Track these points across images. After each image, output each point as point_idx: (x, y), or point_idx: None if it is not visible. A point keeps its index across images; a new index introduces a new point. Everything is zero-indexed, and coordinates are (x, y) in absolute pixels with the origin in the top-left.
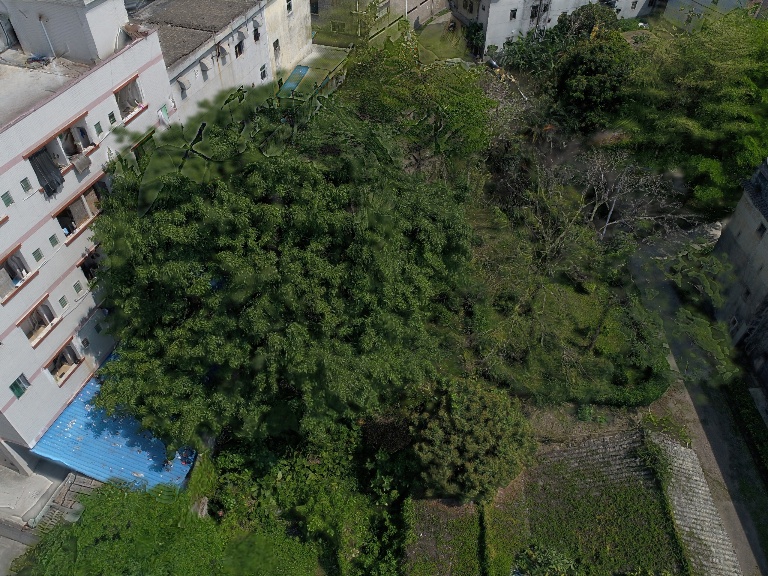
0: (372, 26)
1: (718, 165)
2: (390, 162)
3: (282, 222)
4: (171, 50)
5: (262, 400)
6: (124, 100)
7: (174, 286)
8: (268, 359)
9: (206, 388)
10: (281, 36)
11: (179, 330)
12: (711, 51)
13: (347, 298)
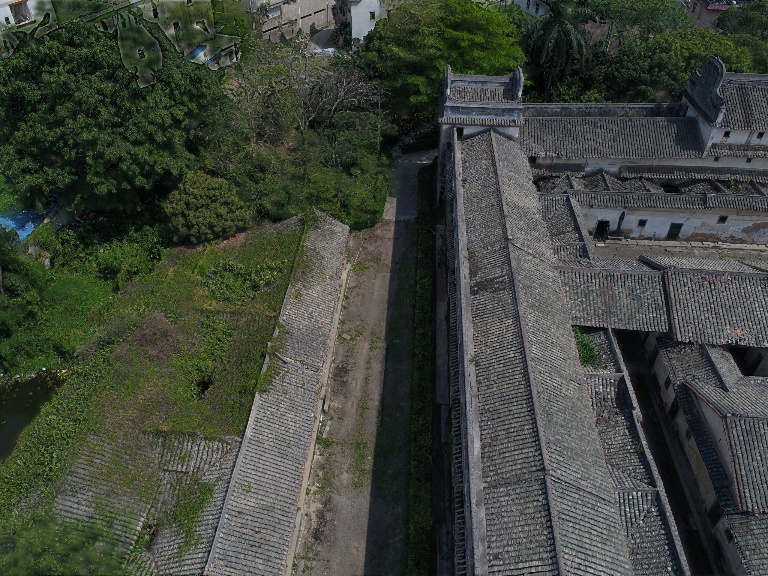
0: (265, 22)
1: (423, 80)
2: (174, 51)
3: (78, 58)
4: (81, 12)
5: (72, 172)
6: (19, 14)
7: (26, 105)
8: (66, 134)
9: (41, 165)
10: (181, 19)
11: (24, 125)
12: (412, 5)
13: (116, 105)
